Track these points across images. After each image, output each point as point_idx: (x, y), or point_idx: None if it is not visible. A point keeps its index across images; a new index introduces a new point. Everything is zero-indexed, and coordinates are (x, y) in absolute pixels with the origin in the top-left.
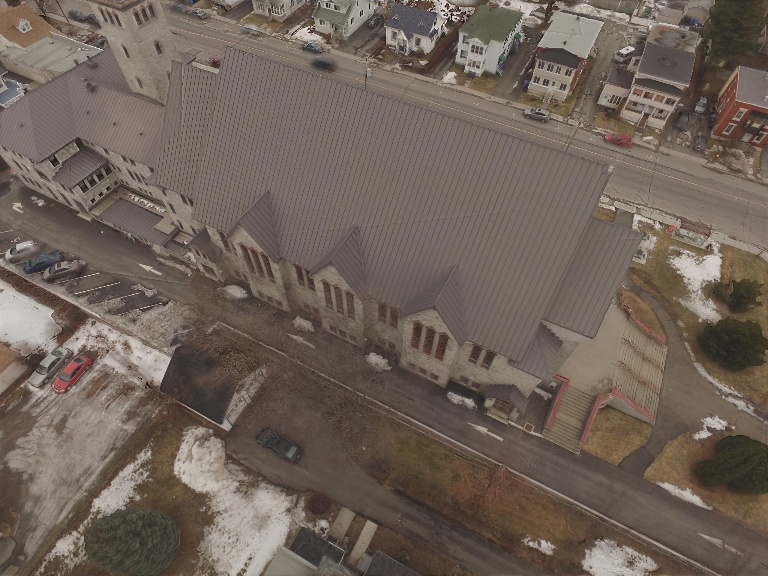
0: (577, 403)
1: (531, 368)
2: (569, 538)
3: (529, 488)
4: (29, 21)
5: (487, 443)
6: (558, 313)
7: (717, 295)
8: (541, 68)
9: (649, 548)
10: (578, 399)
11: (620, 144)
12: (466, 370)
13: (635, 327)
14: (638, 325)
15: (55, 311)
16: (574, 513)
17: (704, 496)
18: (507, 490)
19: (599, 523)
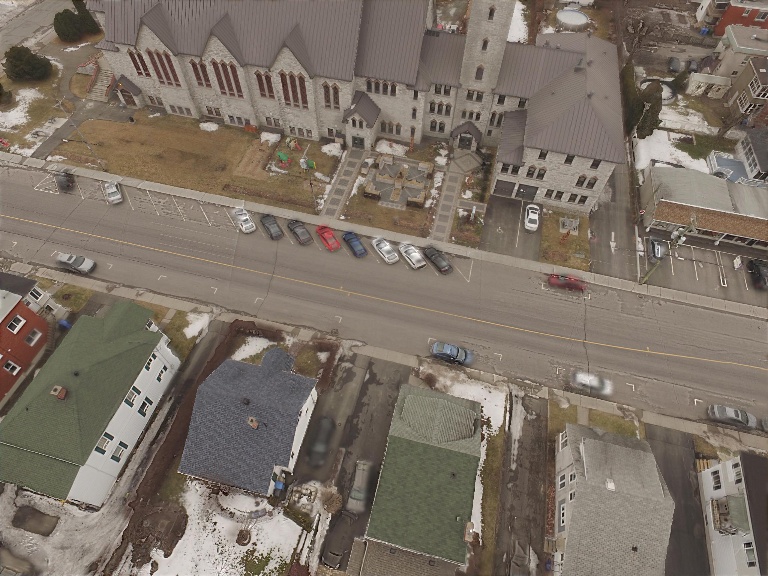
0: None
1: None
2: None
3: None
4: None
5: None
6: None
7: None
8: None
9: None
10: None
11: None
12: None
13: None
14: None
15: None
16: None
17: None
18: None
19: None
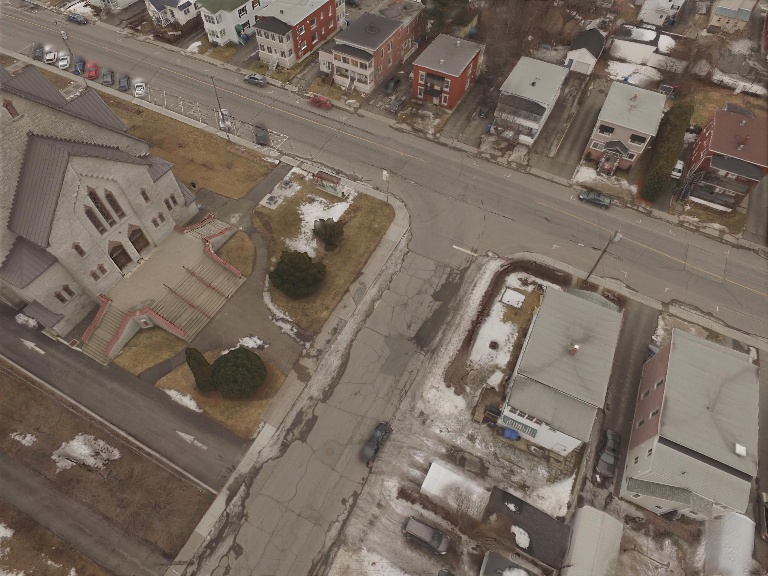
0: (114, 321)
1: (10, 277)
2: (53, 432)
3: (39, 391)
4: None
5: (27, 355)
6: (22, 226)
7: (315, 234)
8: (260, 36)
9: (119, 441)
10: (116, 317)
11: (319, 106)
12: (14, 290)
13: (211, 259)
14: (211, 257)
15: None
16: (67, 412)
17: (199, 401)
18: (22, 393)
19: (85, 420)
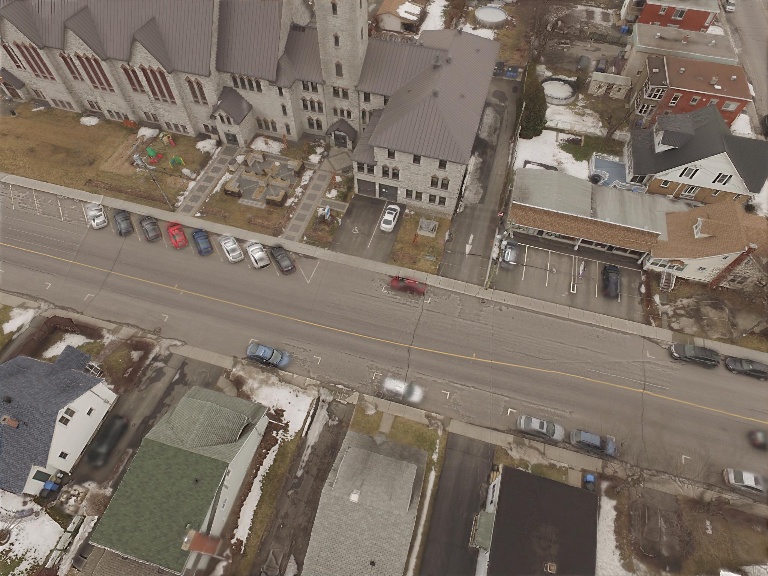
0: None
1: None
2: None
3: None
4: (704, 234)
5: None
6: None
7: None
8: None
9: None
10: None
11: None
12: None
13: None
14: None
15: (373, 29)
16: None
17: None
18: None
19: None
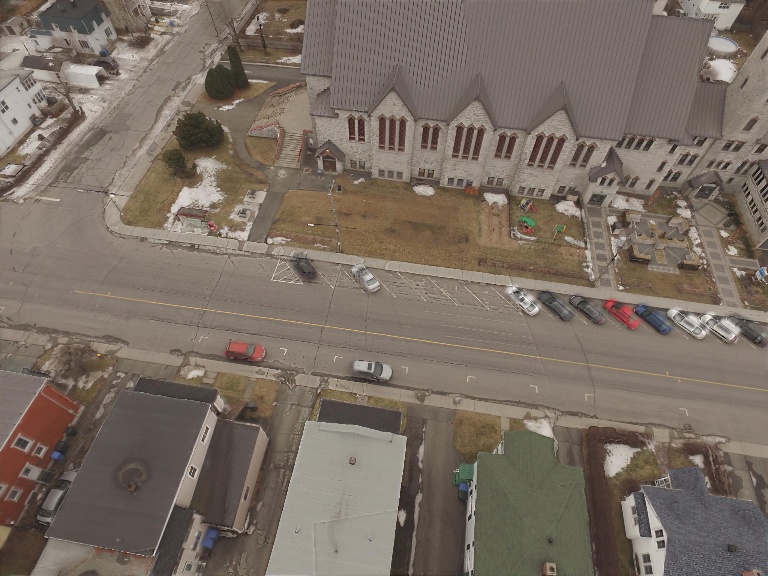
0: None
1: None
2: None
3: None
4: None
5: None
6: None
7: None
8: None
9: None
10: None
11: None
12: None
13: None
14: None
15: None
16: None
17: None
18: None
19: None
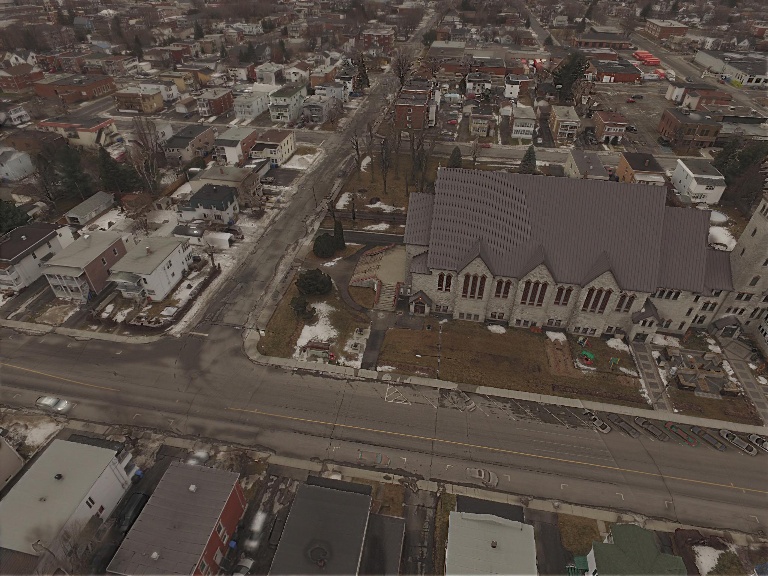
0: None
1: None
2: None
3: None
4: None
5: None
6: None
7: None
8: None
9: None
10: None
11: None
12: None
13: None
14: None
15: None
16: None
17: None
18: None
19: None
